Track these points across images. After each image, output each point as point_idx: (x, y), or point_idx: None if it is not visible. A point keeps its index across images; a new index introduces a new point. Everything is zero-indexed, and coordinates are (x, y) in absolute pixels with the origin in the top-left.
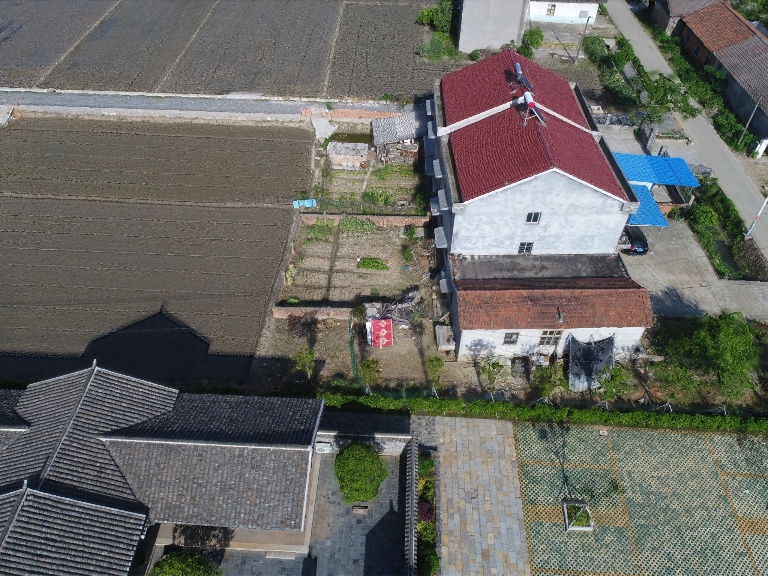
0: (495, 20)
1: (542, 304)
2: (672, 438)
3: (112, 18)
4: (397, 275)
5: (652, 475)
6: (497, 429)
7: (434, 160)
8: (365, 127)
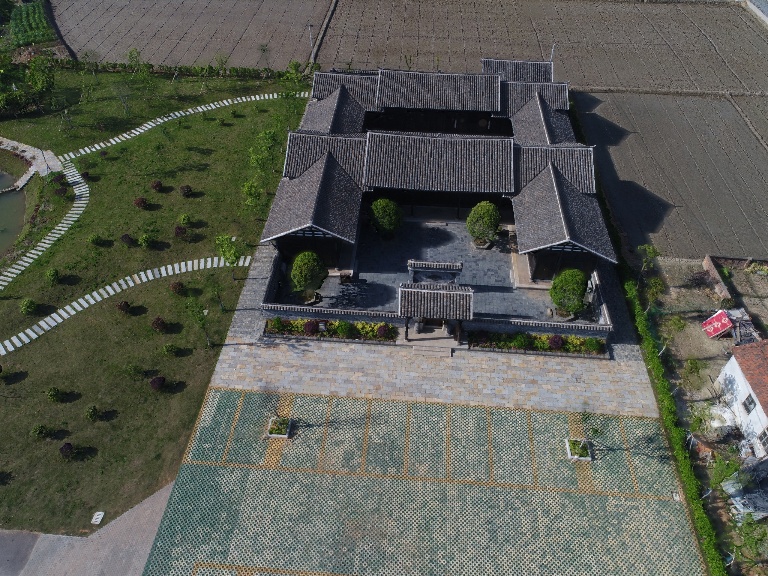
0: None
1: None
2: (695, 567)
3: None
4: None
5: (640, 529)
6: (647, 404)
7: None
8: None
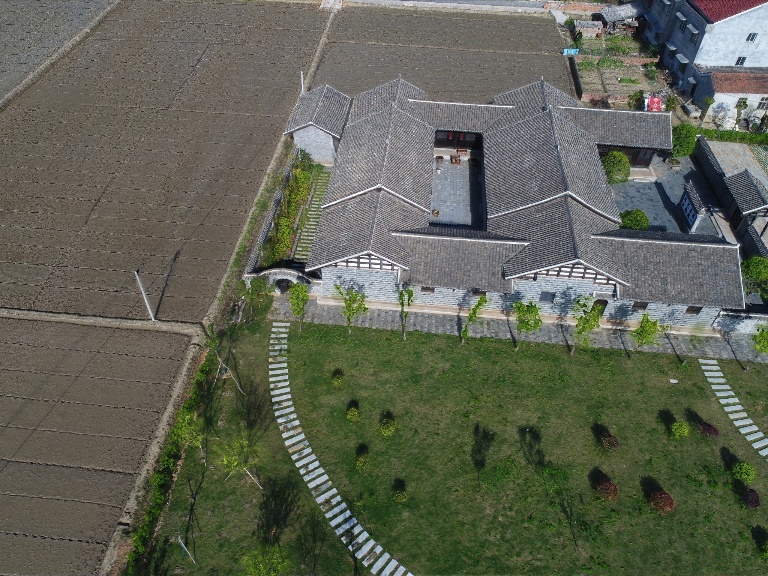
0: None
1: (762, 81)
2: None
3: None
4: (648, 86)
5: None
6: (739, 146)
7: (677, 13)
8: (588, 17)
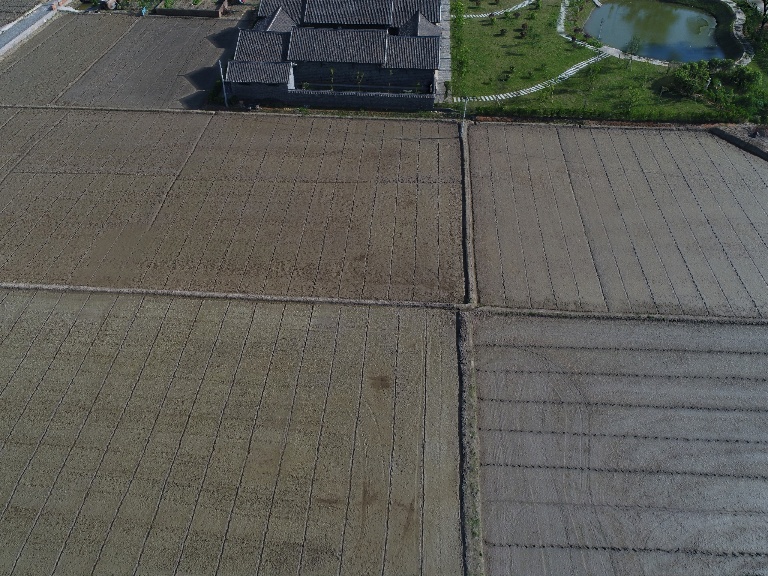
0: None
1: None
2: None
3: None
4: None
5: None
6: None
7: None
8: (77, 1)
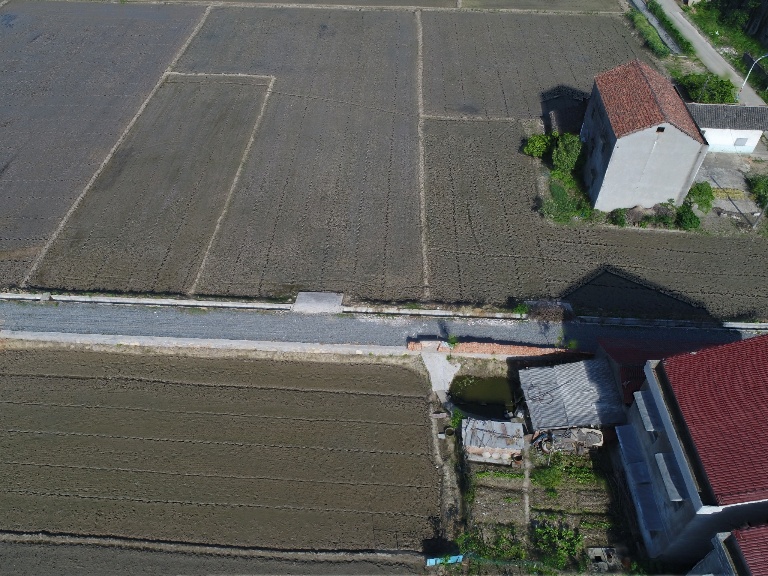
0: (652, 176)
1: None
2: None
3: (127, 148)
4: None
5: None
6: None
7: (705, 575)
8: (499, 366)
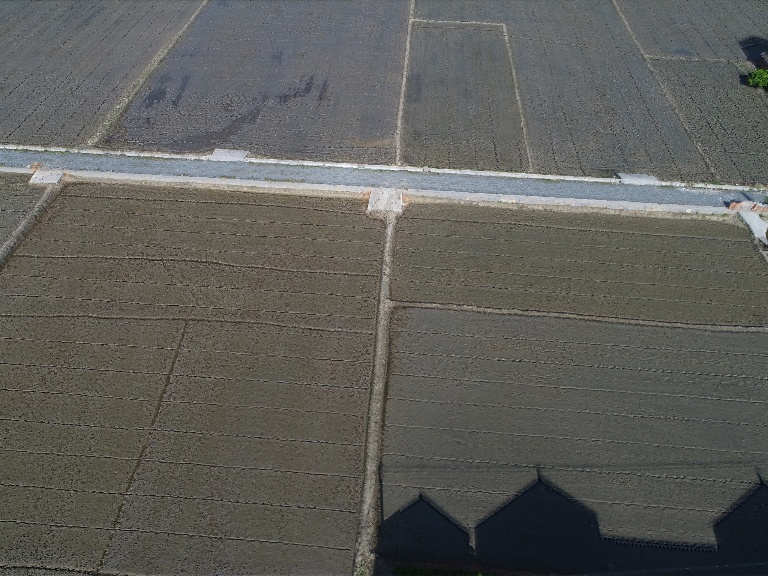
0: None
1: None
2: None
3: (414, 73)
4: None
5: None
6: None
7: None
8: None
